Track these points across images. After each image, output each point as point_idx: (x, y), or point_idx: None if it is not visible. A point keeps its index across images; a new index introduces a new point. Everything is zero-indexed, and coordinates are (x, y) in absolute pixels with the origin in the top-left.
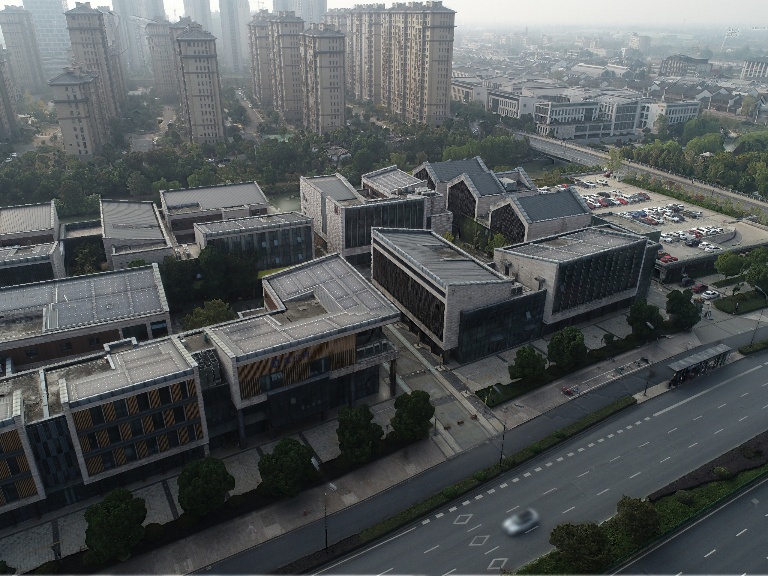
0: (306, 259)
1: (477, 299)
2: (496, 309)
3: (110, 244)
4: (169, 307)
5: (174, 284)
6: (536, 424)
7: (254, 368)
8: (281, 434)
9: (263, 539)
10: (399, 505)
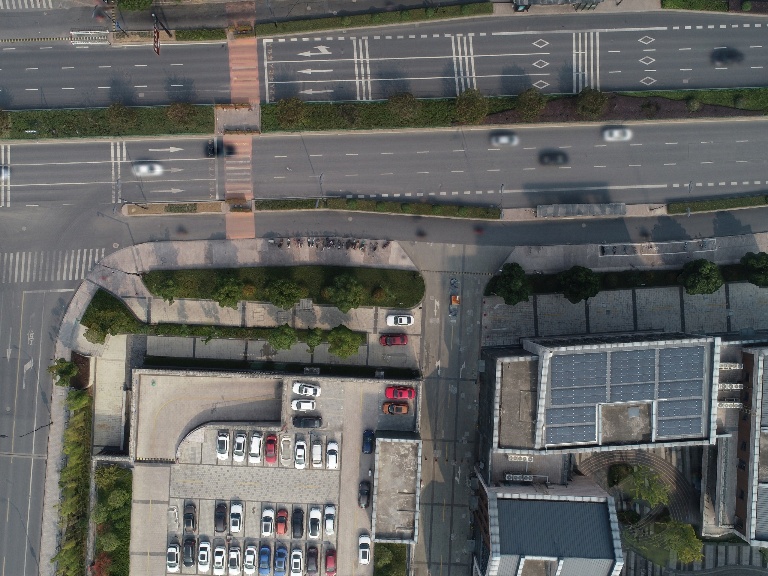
0: None
1: None
2: None
3: None
4: None
5: None
6: (767, 225)
7: None
8: None
9: None
10: None
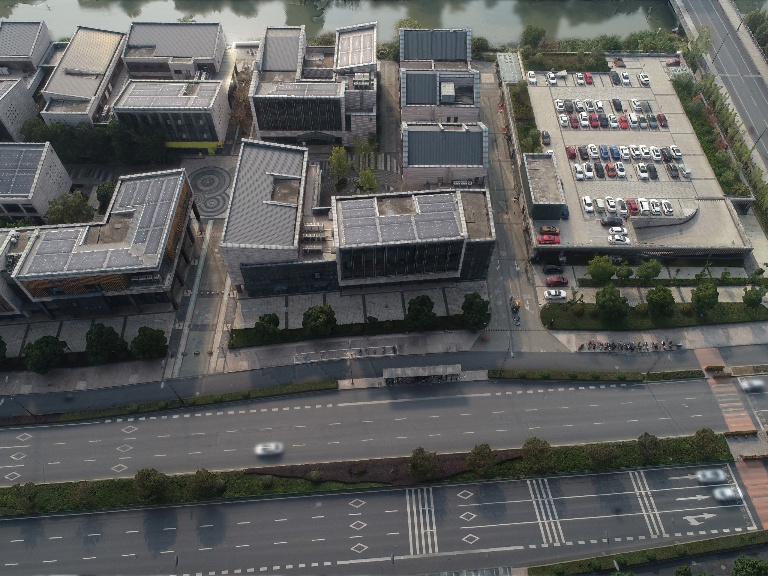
0: (212, 138)
1: (257, 257)
2: (277, 268)
3: (48, 96)
4: (94, 159)
5: (92, 144)
6: (247, 376)
7: (35, 283)
8: (82, 316)
9: (17, 392)
10: (104, 402)
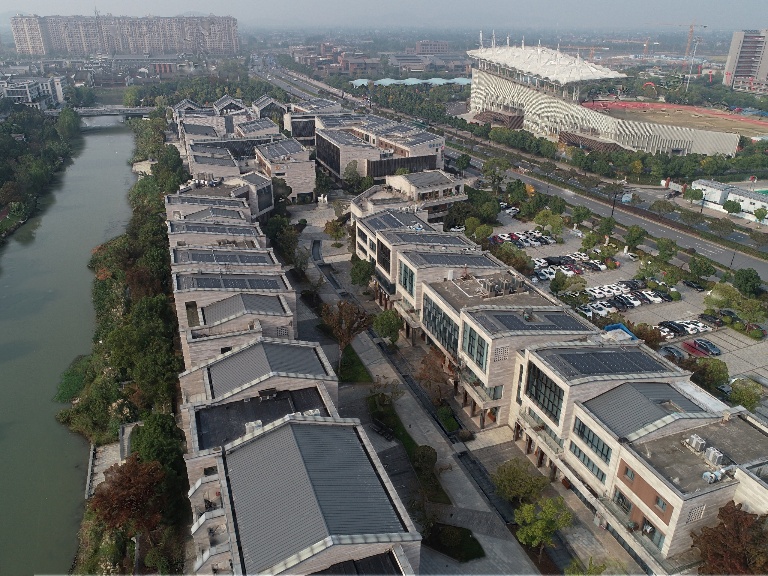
0: None
1: None
2: None
3: None
4: None
5: None
6: None
7: None
8: None
9: None
10: None
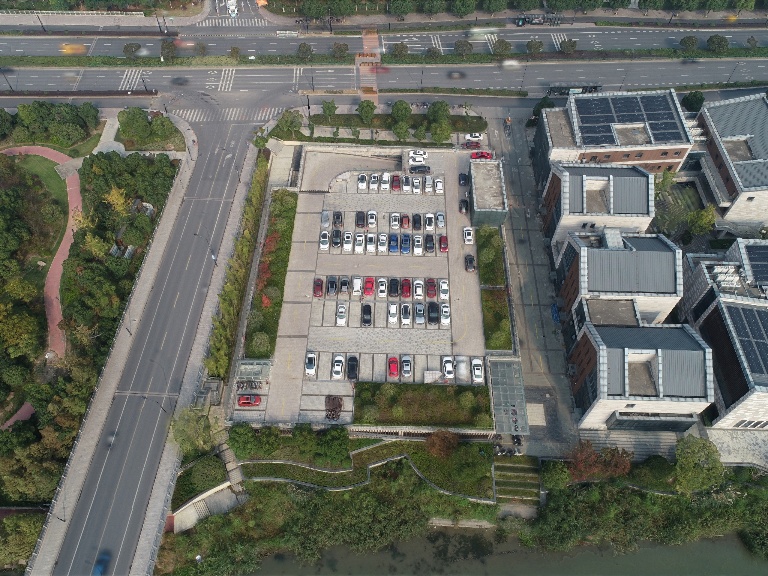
0: None
1: None
2: None
3: None
4: None
5: None
6: None
7: None
8: None
9: None
10: None
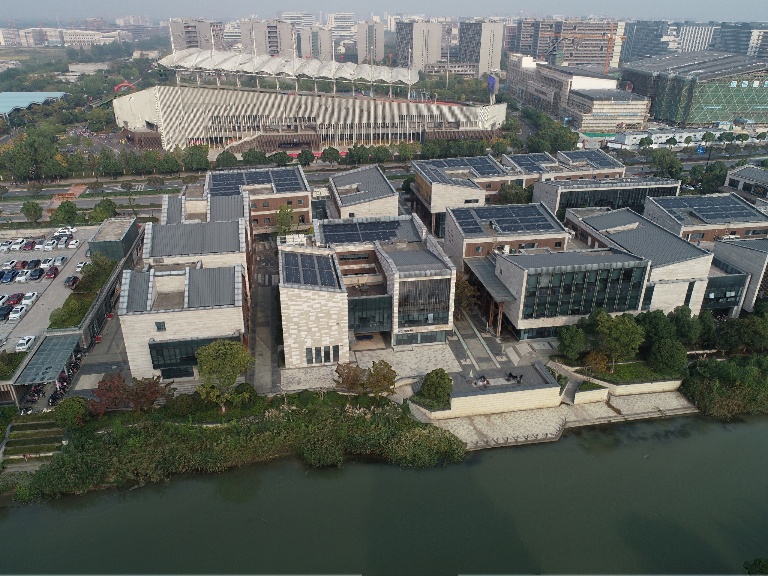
0: None
1: None
2: None
3: None
4: None
5: None
6: None
7: None
8: None
9: None
10: None
